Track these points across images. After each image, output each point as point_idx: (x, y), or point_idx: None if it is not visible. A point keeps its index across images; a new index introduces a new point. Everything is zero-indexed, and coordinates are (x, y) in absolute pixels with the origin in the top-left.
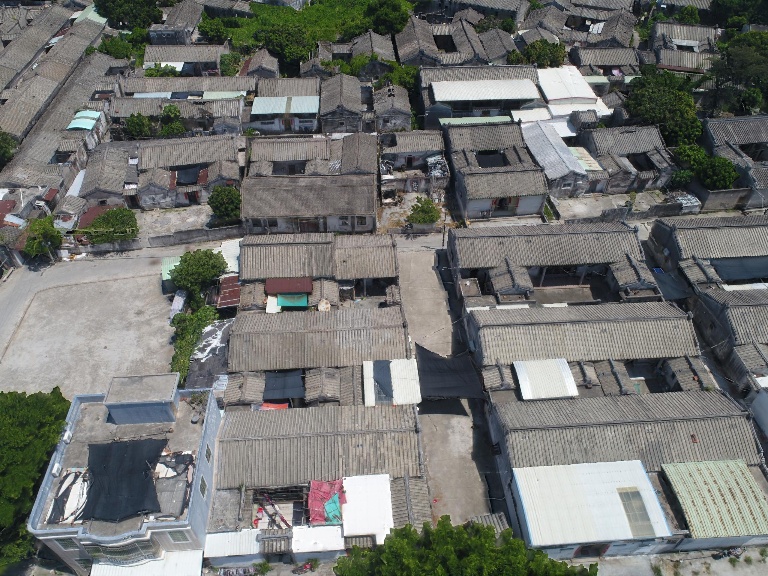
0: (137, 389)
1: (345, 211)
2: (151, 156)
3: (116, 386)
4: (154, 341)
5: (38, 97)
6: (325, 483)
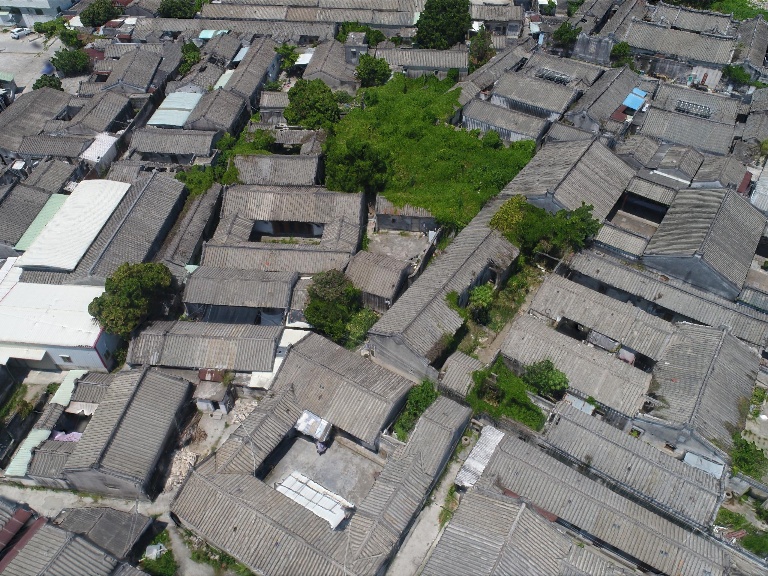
0: None
1: None
2: None
3: None
4: None
5: (256, 14)
6: None
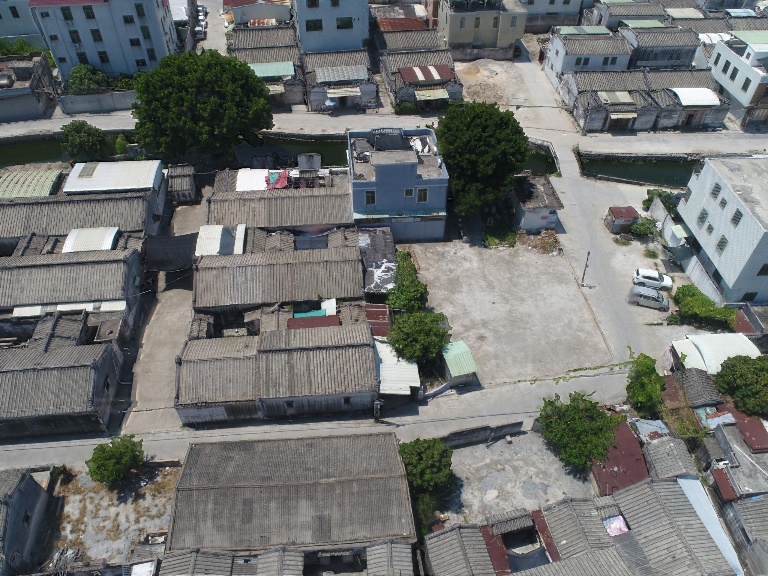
0: (397, 157)
1: (237, 446)
2: (613, 574)
3: (412, 158)
4: (450, 310)
5: None
6: (278, 187)
